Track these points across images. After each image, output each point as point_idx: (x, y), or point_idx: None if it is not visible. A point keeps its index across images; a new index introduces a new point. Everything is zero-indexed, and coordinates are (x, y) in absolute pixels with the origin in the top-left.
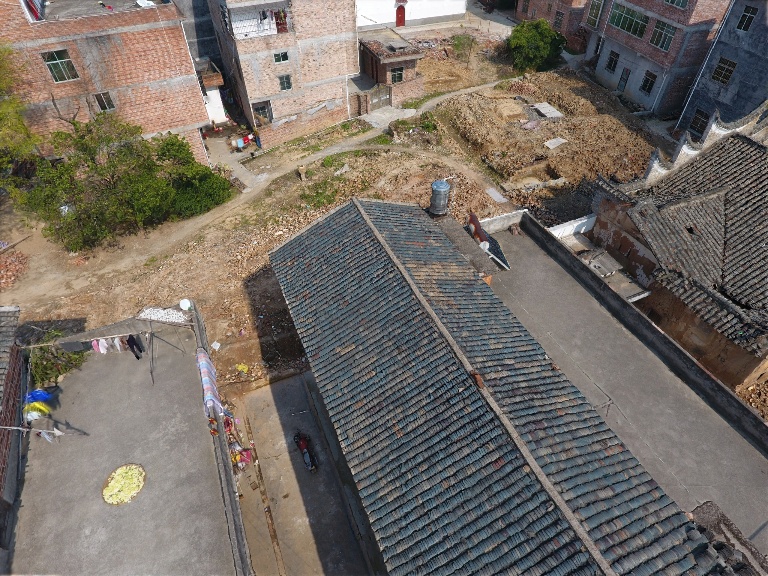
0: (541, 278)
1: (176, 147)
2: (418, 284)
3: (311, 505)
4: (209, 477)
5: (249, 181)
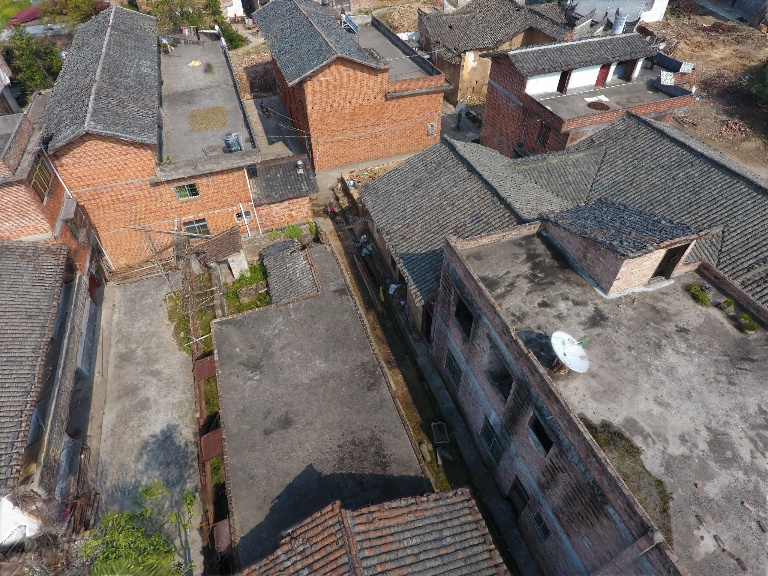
0: (370, 35)
1: (214, 2)
2: (302, 7)
3: (265, 125)
4: (223, 63)
5: (254, 41)
